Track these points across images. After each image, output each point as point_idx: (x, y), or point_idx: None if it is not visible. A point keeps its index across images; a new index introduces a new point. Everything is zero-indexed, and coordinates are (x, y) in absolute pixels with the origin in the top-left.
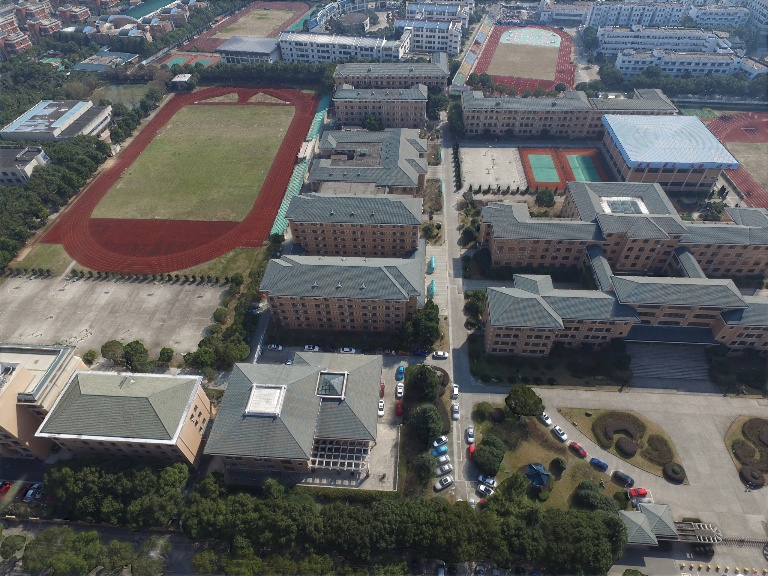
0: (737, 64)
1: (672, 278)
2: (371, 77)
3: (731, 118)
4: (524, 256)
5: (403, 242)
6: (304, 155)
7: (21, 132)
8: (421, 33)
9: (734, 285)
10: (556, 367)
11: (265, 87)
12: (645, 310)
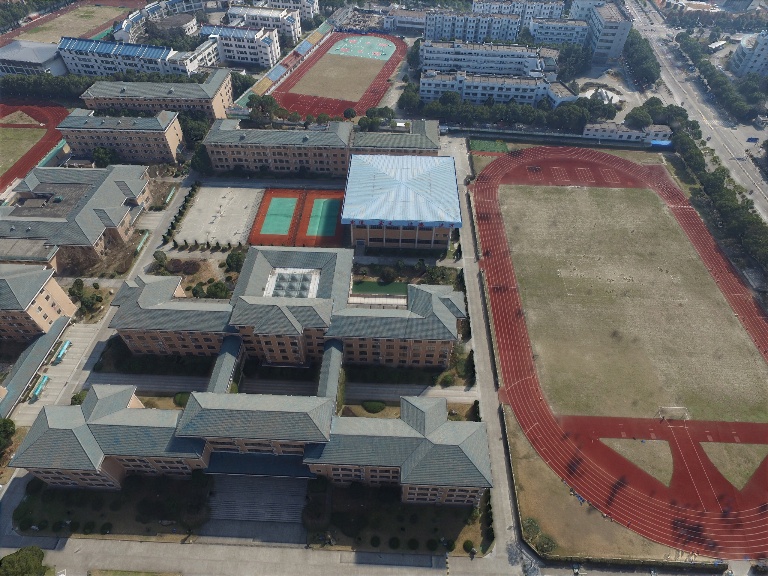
0: (544, 90)
1: (260, 397)
2: (125, 99)
3: (521, 153)
4: (163, 345)
5: (23, 326)
6: (5, 197)
7: None
8: (230, 42)
9: (329, 407)
10: (124, 506)
11: (29, 104)
12: (218, 440)
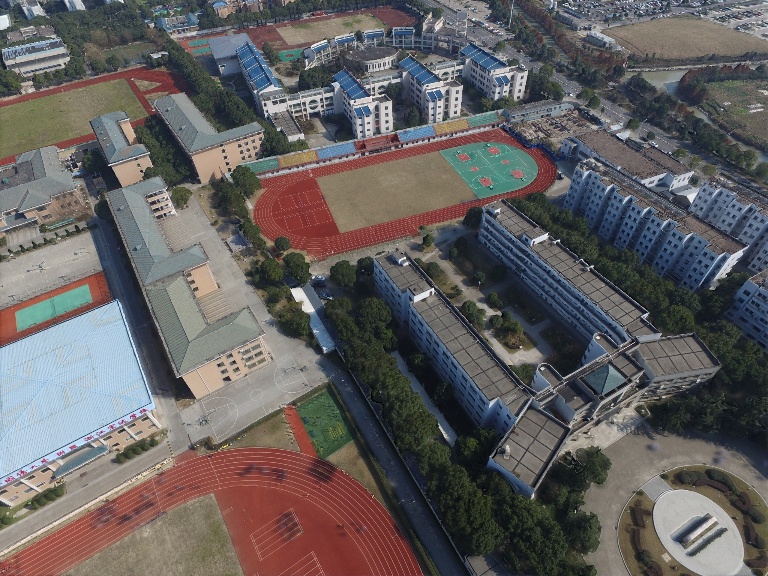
0: (507, 417)
1: None
2: None
3: (331, 480)
4: None
5: None
6: None
7: (2, 54)
8: None
9: None
10: None
11: (182, 89)
12: None
